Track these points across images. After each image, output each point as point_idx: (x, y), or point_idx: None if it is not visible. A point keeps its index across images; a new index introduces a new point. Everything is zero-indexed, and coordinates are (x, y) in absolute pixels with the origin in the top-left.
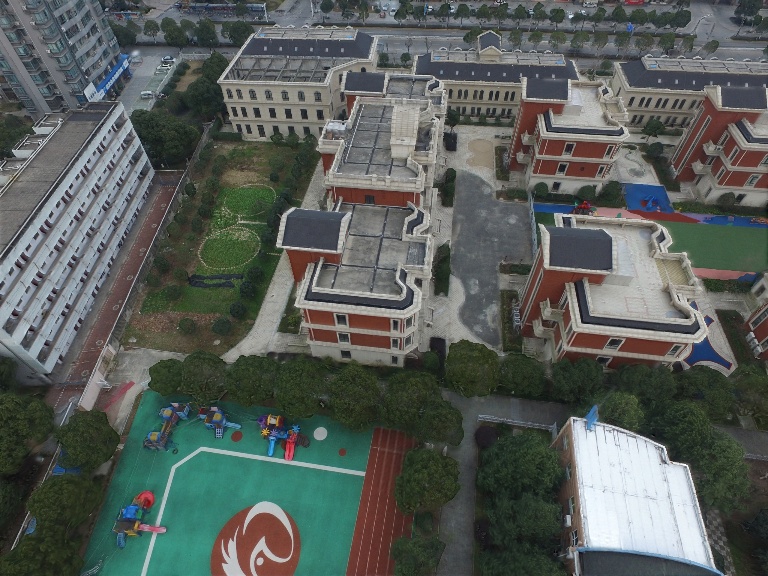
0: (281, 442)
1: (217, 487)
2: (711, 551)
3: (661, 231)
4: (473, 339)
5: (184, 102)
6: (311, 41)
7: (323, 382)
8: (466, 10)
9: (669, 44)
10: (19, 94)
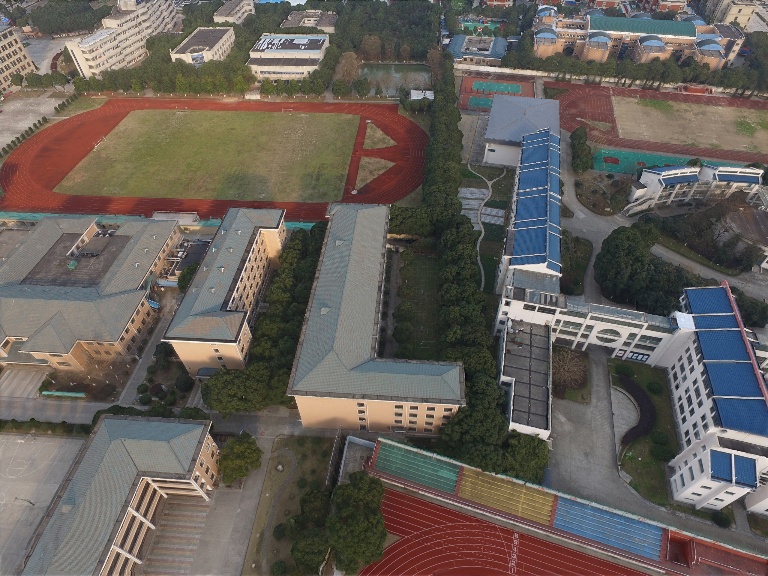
0: None
1: None
2: None
3: None
4: (521, 16)
5: None
6: None
7: (493, 8)
8: None
9: None
10: None
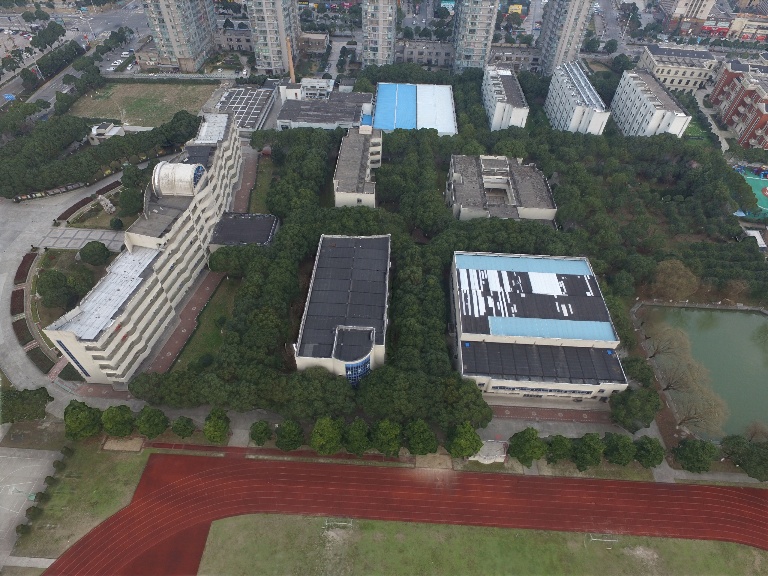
0: (763, 176)
1: (751, 183)
2: None
3: None
4: None
5: (603, 76)
6: (687, 51)
7: None
8: (720, 42)
9: None
10: (549, 65)
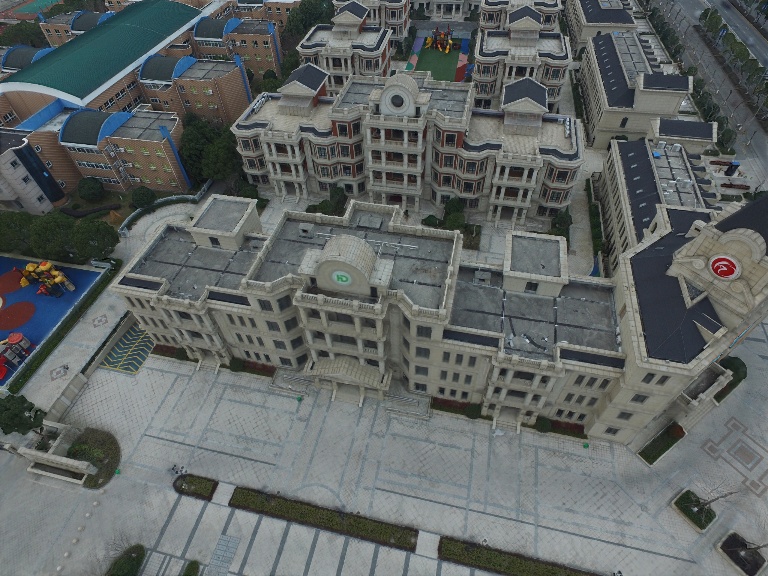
0: None
1: None
2: (269, 2)
3: (395, 2)
4: None
5: None
6: None
7: None
8: None
9: (767, 99)
10: None
